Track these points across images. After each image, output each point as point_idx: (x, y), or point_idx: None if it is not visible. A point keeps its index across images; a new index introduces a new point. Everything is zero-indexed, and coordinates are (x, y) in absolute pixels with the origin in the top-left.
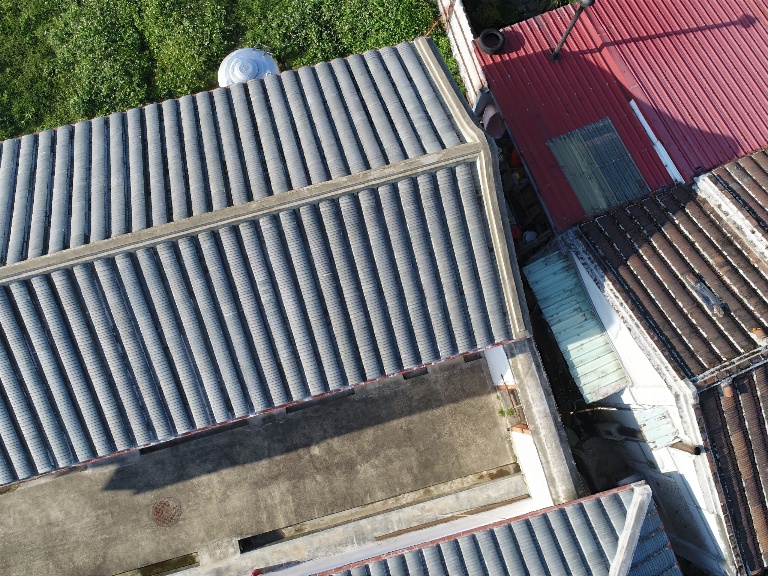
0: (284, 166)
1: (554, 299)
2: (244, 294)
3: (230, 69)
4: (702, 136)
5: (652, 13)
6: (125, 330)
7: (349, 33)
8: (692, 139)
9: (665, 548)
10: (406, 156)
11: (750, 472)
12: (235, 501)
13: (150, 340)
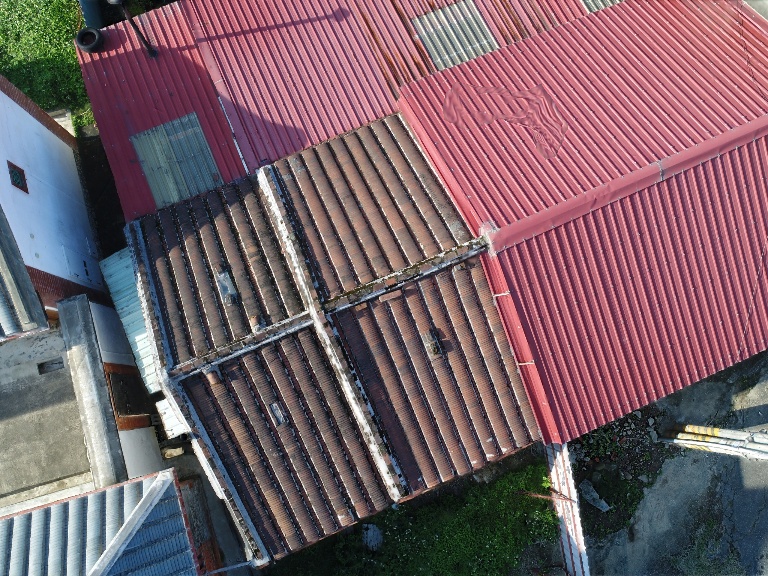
0: None
1: (126, 292)
2: None
3: None
4: (274, 129)
5: (250, 9)
6: None
7: (1, 34)
8: (264, 132)
9: (180, 533)
10: None
11: (255, 457)
12: None
13: None
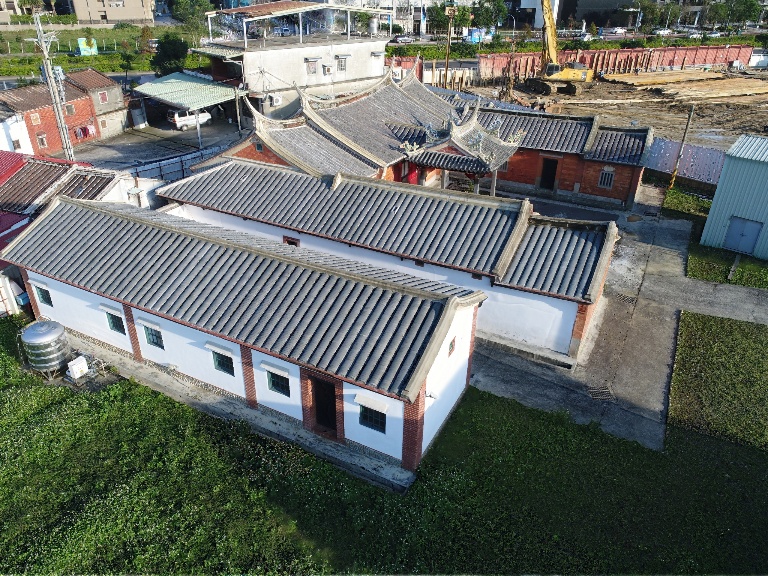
0: None
1: None
2: None
3: (44, 332)
4: None
5: None
6: None
7: None
8: None
9: None
10: None
11: None
12: None
13: None
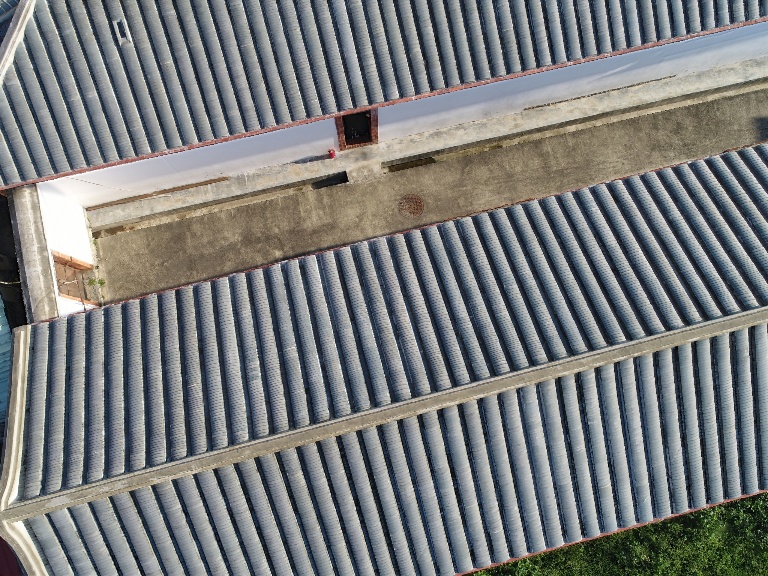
0: (229, 504)
1: (5, 376)
2: (274, 367)
3: None
4: None
5: None
6: (387, 335)
7: None
8: None
9: None
10: (94, 511)
11: None
12: (351, 213)
13: (365, 326)
